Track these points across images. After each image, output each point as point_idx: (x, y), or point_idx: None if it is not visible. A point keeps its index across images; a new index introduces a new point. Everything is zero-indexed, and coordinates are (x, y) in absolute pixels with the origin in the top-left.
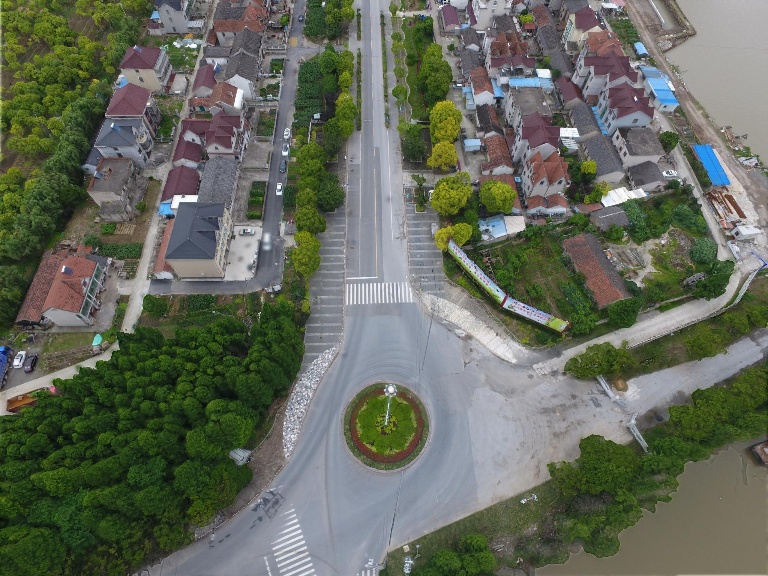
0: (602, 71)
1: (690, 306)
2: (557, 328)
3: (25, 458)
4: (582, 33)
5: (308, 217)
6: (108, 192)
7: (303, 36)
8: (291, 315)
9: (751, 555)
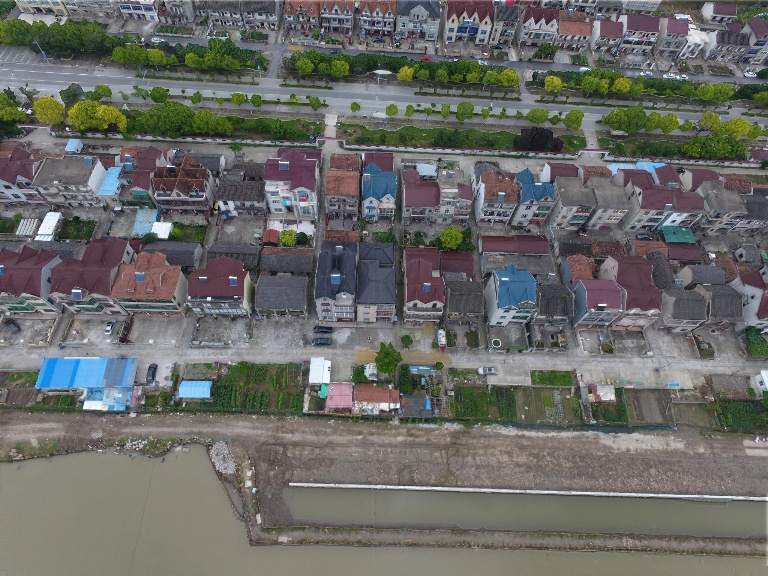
0: None
1: None
2: None
3: None
4: None
5: None
6: None
7: None
8: None
9: None
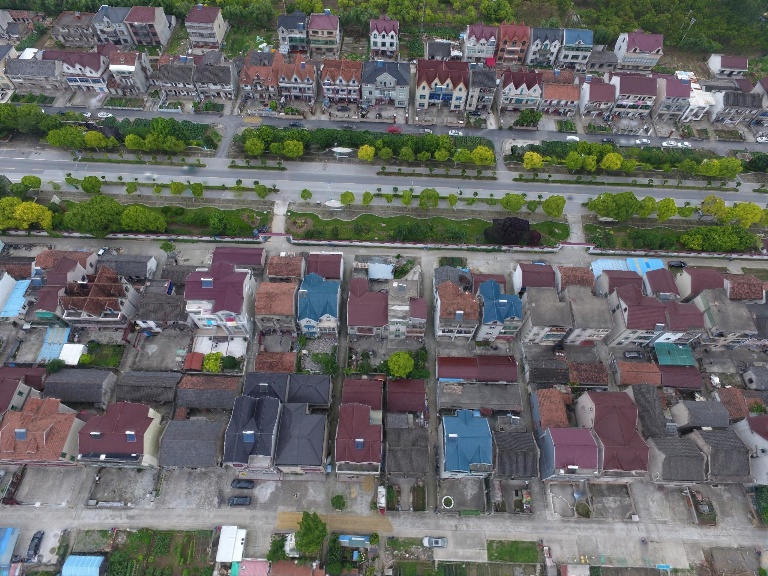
0: None
1: None
2: None
3: None
4: None
5: None
6: (57, 20)
7: None
8: None
9: None
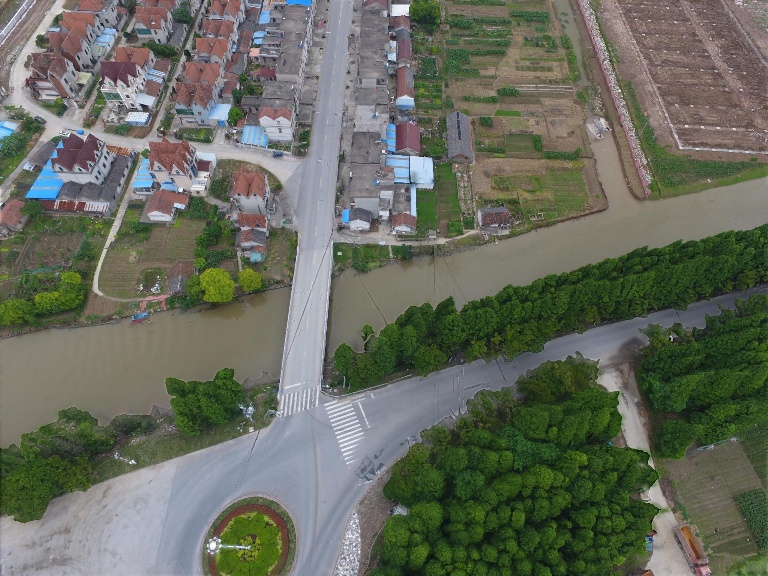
0: None
1: None
2: None
3: (590, 504)
4: None
5: None
6: None
7: None
8: None
9: None
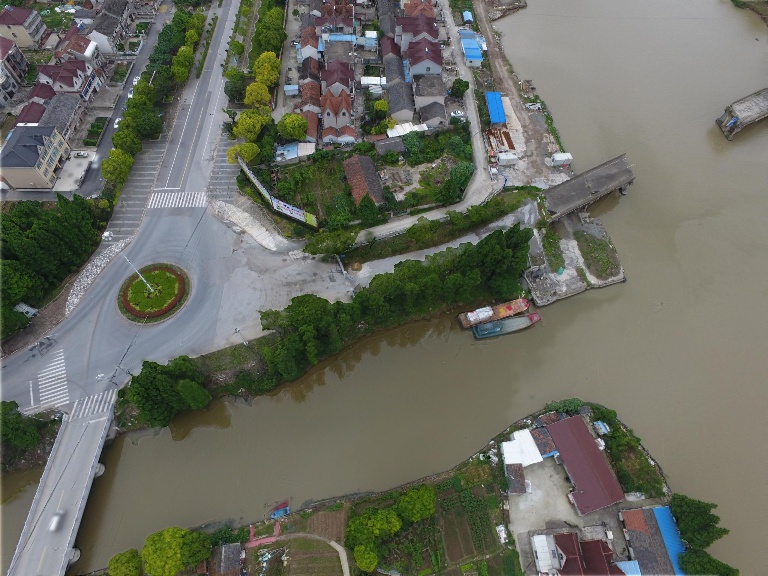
0: (409, 29)
1: (437, 212)
2: (313, 224)
3: None
4: (409, 1)
5: (121, 137)
6: None
7: (173, 4)
8: (87, 208)
9: (448, 398)
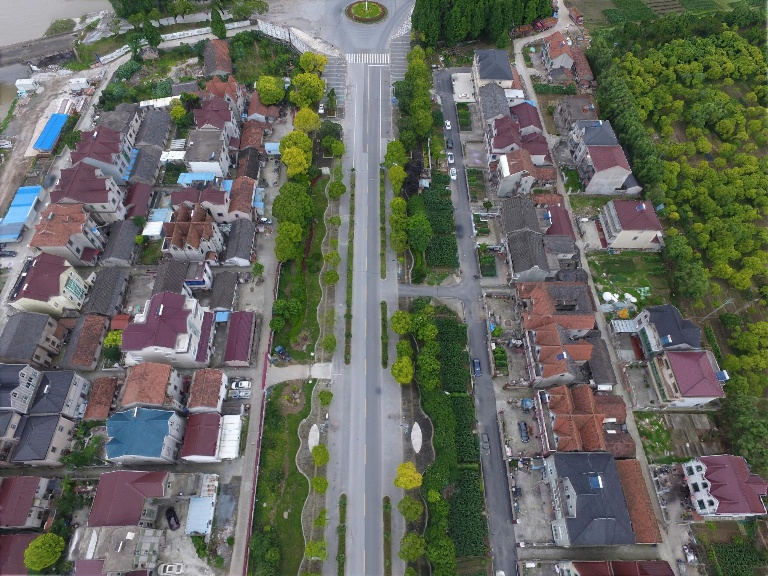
0: None
1: None
2: None
3: None
4: None
5: (418, 66)
6: (574, 96)
7: None
8: None
9: None
